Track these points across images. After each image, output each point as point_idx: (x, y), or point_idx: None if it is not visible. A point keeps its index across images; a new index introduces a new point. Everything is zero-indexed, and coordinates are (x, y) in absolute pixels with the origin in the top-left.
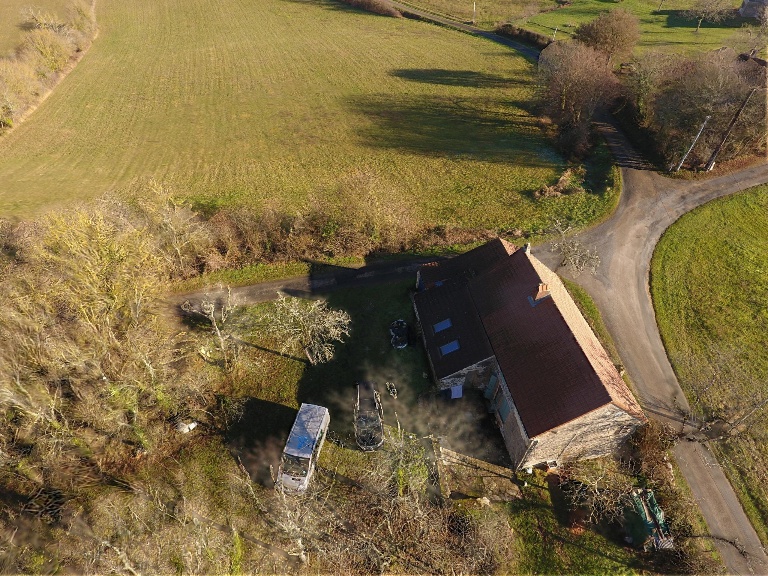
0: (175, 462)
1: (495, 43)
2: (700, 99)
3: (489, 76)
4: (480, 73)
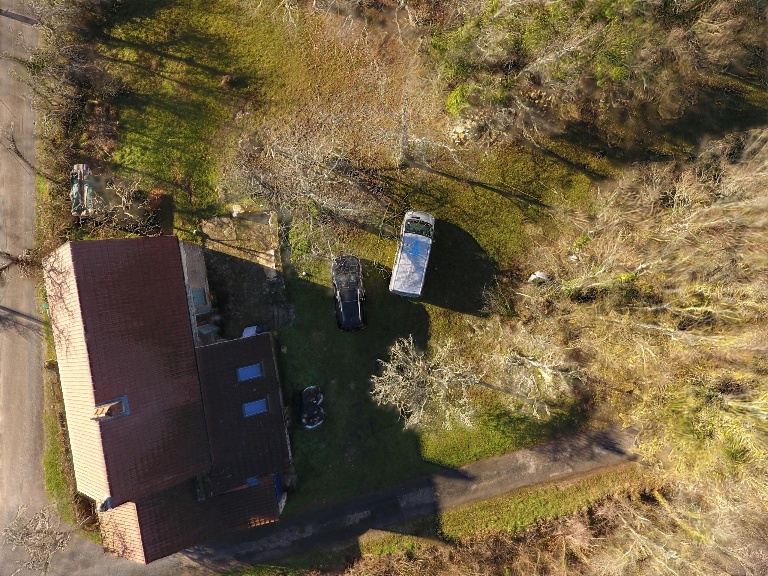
0: (538, 242)
1: None
2: None
3: None
4: None
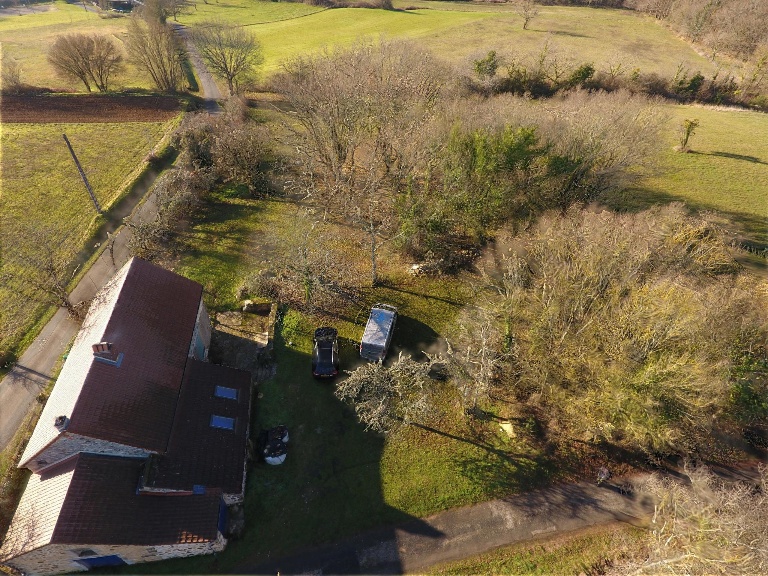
0: None
1: None
2: None
3: None
4: None
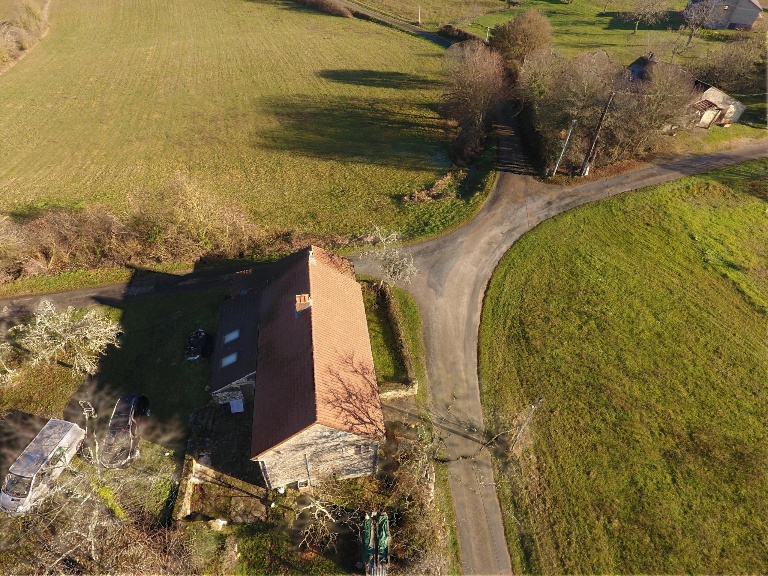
0: None
1: (433, 44)
2: (568, 103)
3: (414, 77)
4: (406, 74)
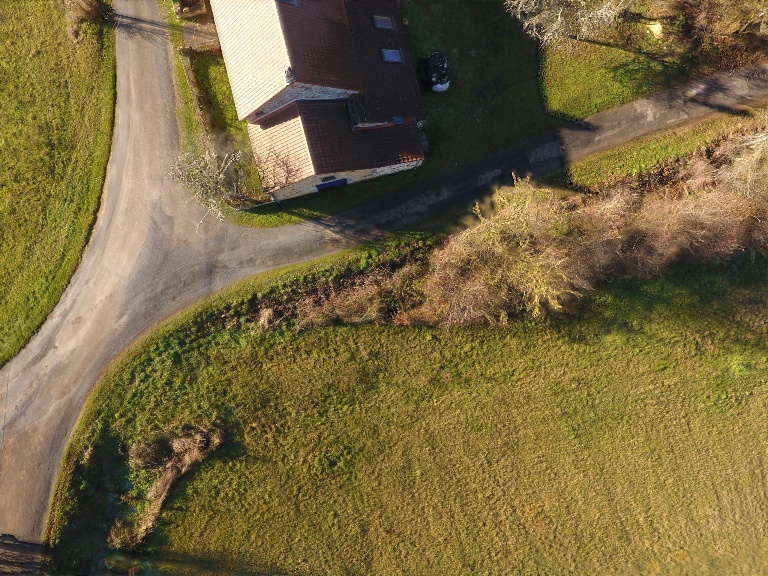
0: None
1: None
2: None
3: None
4: None
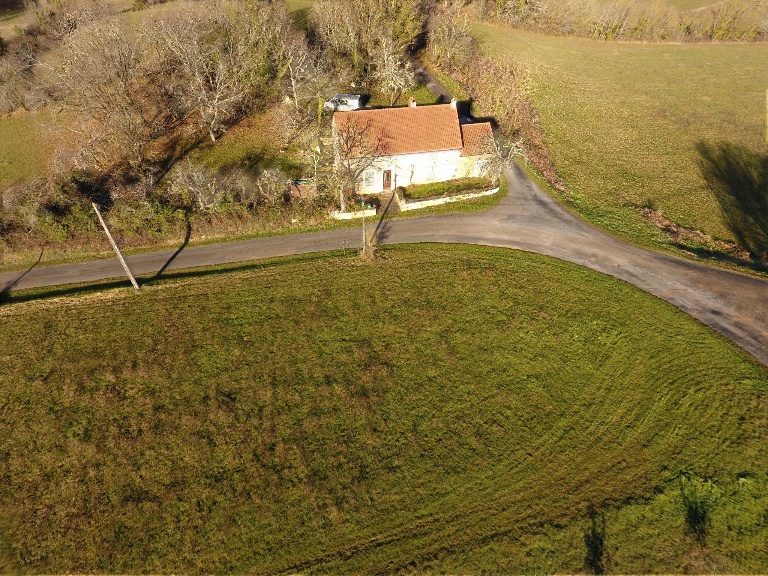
0: None
1: None
2: None
3: None
4: None
